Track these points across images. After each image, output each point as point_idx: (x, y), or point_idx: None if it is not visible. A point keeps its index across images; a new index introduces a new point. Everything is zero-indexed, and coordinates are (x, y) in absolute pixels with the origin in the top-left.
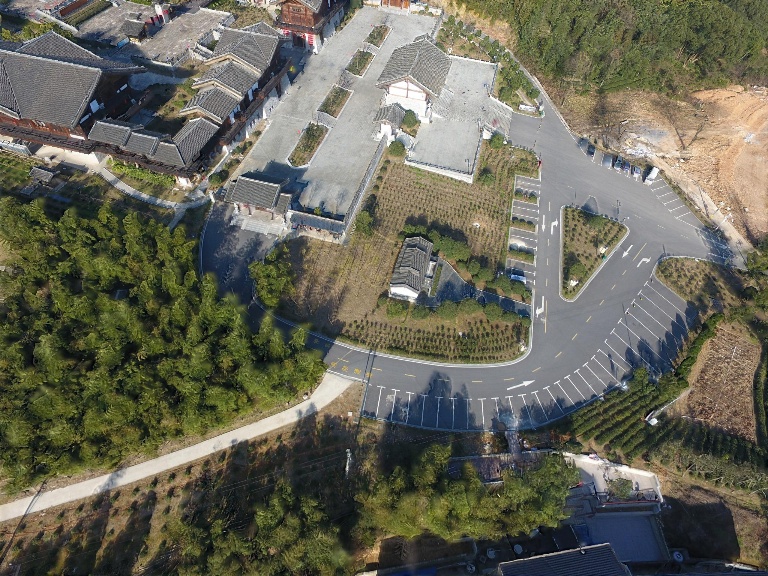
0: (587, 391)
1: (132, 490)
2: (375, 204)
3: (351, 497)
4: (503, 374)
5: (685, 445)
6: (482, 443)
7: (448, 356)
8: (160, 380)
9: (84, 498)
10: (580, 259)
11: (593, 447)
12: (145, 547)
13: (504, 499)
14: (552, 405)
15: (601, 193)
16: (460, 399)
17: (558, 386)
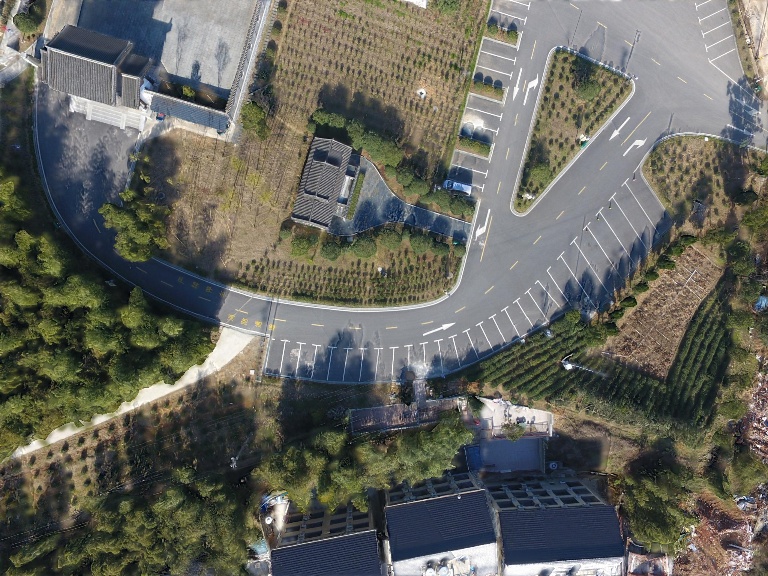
0: (510, 332)
1: (46, 454)
2: (276, 61)
3: (257, 448)
4: (422, 317)
5: (593, 385)
6: (388, 394)
7: (362, 299)
8: (29, 371)
9: (3, 463)
10: (551, 148)
11: (500, 390)
12: (74, 497)
13: (394, 464)
14: (468, 350)
15: (617, 17)
16: (370, 349)
17: (480, 328)
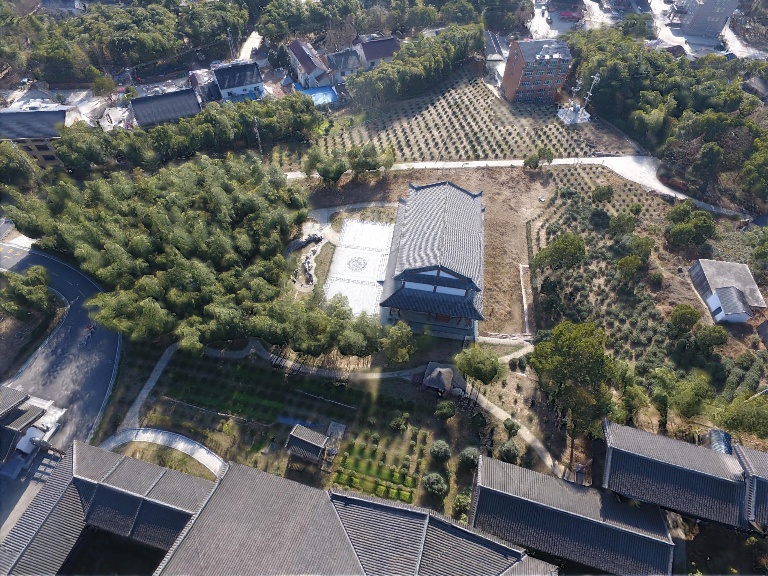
0: None
1: None
2: None
3: None
4: None
5: None
6: None
7: None
8: None
9: None
10: None
11: None
12: None
13: None
14: None
15: None
16: None
17: None
